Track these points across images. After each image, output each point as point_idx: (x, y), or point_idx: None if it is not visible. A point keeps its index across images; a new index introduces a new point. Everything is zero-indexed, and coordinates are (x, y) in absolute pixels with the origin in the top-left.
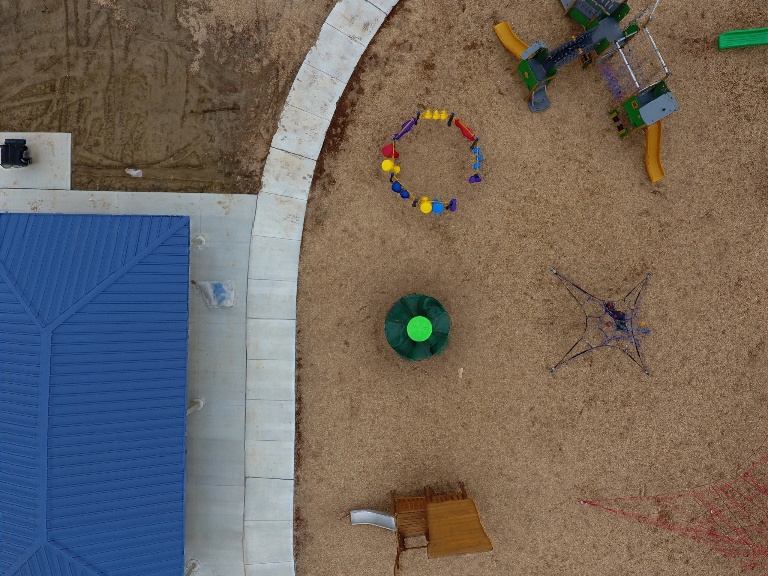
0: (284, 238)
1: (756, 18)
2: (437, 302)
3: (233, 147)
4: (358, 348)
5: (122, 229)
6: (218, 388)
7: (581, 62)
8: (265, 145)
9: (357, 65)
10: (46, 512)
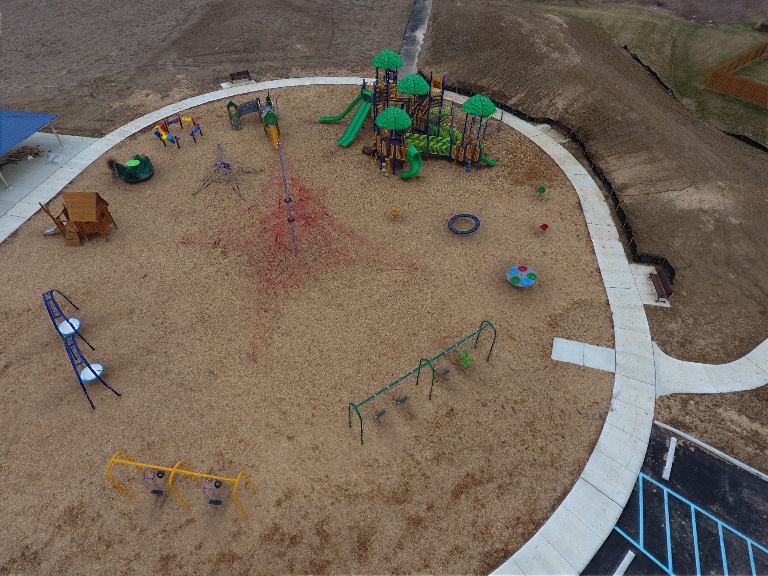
0: (101, 149)
1: None
2: None
3: None
4: (105, 180)
5: None
6: (24, 185)
7: (260, 121)
8: (115, 128)
9: None
10: None
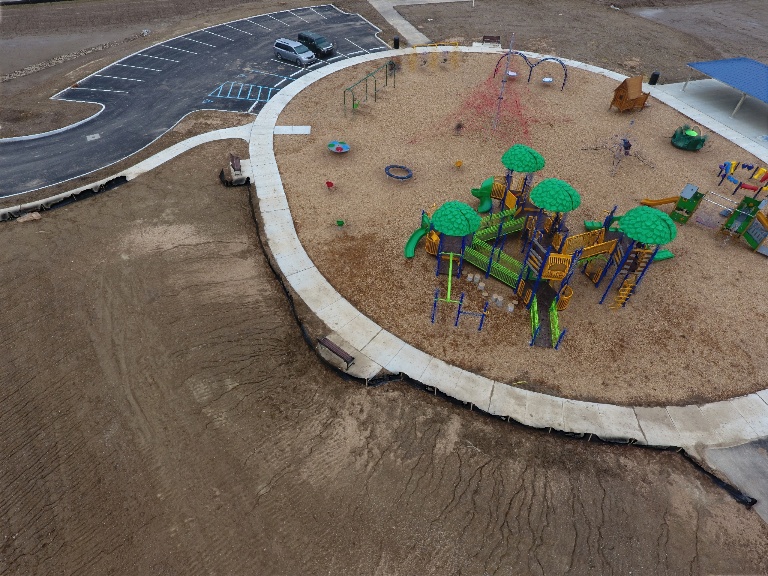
0: None
1: None
2: (694, 141)
3: None
4: None
5: None
6: None
7: None
8: None
9: None
10: (760, 64)
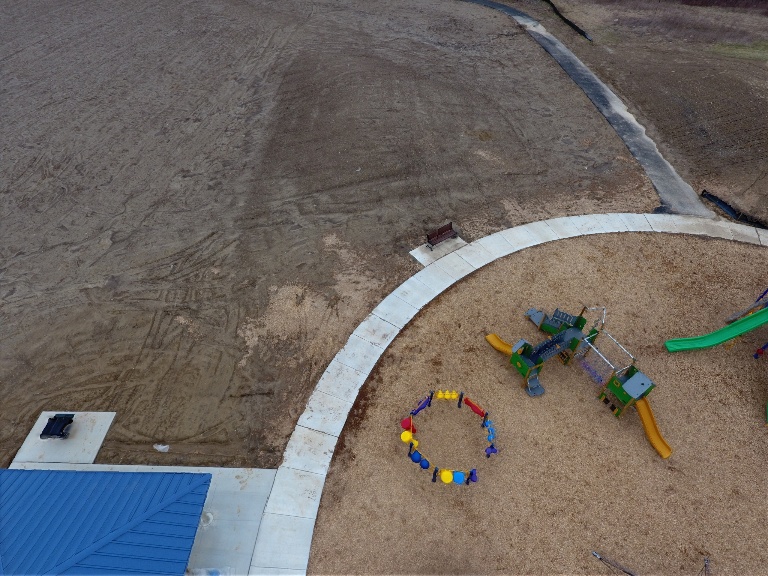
0: (298, 516)
1: (687, 333)
2: None
3: (262, 425)
4: None
5: (140, 485)
6: None
7: (561, 360)
8: (292, 423)
9: (377, 362)
10: None
